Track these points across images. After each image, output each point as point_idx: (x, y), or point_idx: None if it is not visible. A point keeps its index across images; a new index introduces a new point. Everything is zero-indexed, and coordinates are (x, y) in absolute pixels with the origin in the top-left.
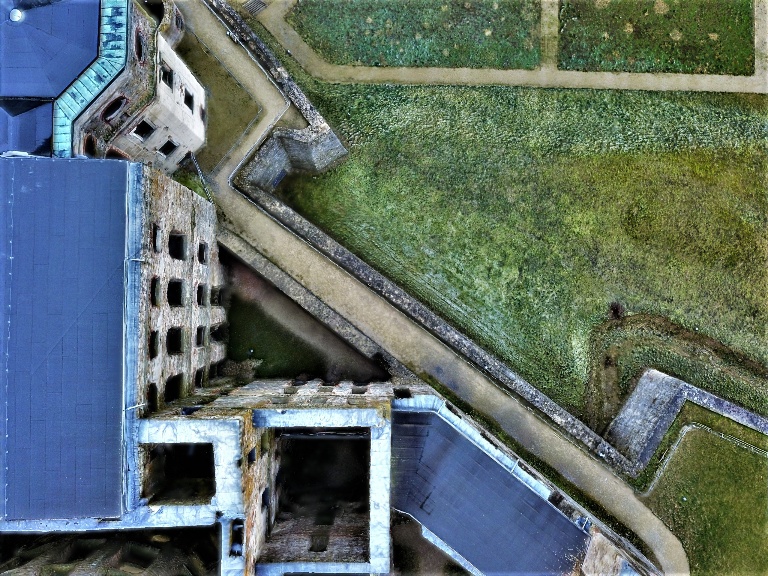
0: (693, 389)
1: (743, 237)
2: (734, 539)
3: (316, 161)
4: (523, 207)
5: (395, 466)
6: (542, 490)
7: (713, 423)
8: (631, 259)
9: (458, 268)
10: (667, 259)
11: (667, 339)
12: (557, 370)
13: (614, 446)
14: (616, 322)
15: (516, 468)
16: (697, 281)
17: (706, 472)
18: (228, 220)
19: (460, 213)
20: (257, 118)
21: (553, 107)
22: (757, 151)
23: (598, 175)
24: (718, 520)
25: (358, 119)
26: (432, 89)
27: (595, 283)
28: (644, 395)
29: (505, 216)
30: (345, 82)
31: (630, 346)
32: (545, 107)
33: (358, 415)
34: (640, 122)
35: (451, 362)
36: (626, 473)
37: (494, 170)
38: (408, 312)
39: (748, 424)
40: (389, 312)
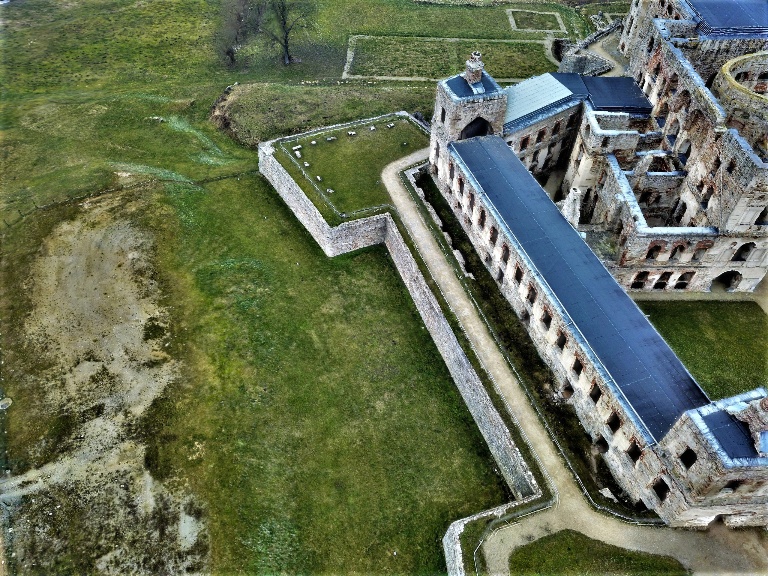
0: None
1: None
2: None
3: None
4: None
5: None
6: None
7: None
8: None
9: None
10: None
11: None
12: None
13: None
14: None
15: None
16: None
17: None
18: None
19: None
20: None
21: None
22: None
23: None
24: None
25: None
26: None
27: None
28: None
29: None
30: None
31: None
32: None
33: None
34: None
35: None
36: None
37: None
38: None
39: None
40: None
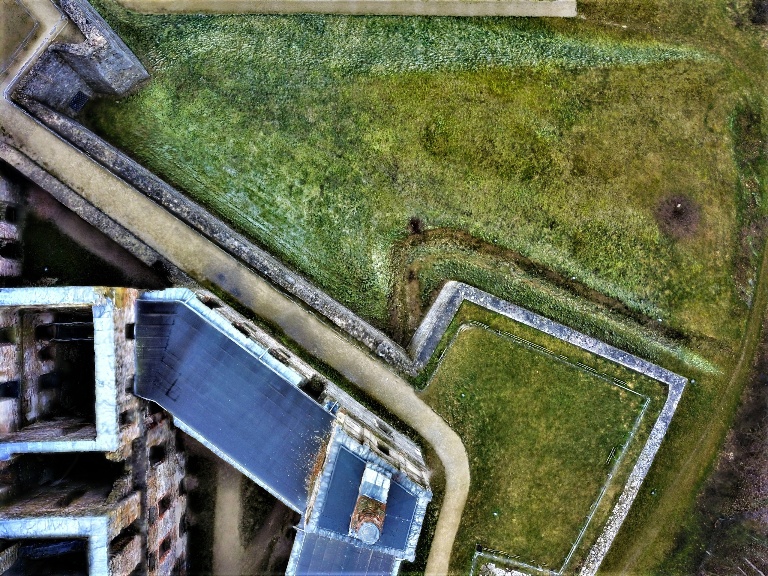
0: (470, 288)
1: (538, 150)
2: (511, 432)
3: (111, 82)
4: (324, 126)
5: (141, 355)
6: (292, 376)
7: (490, 321)
8: (430, 174)
9: (260, 187)
10: (465, 174)
11: (470, 253)
12: (359, 284)
13: (408, 353)
14: (418, 237)
15: (266, 355)
16: (495, 194)
17: (484, 368)
18: (8, 135)
19: (262, 133)
20: (35, 34)
21: (361, 32)
22: (554, 69)
23: (397, 94)
24: (496, 414)
25: (166, 46)
26: (243, 18)
27: (395, 198)
28: (438, 303)
29: (306, 135)
30: (158, 13)
31: (432, 260)
32: (352, 32)
33: (74, 292)
34: (444, 44)
35: (233, 269)
36: (406, 372)
37: (295, 91)
38: (188, 220)
39: (524, 321)
40: (171, 222)
